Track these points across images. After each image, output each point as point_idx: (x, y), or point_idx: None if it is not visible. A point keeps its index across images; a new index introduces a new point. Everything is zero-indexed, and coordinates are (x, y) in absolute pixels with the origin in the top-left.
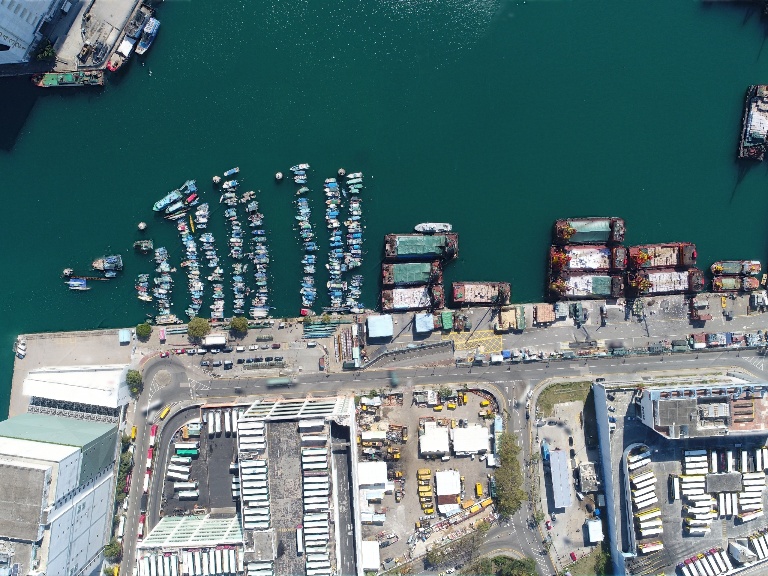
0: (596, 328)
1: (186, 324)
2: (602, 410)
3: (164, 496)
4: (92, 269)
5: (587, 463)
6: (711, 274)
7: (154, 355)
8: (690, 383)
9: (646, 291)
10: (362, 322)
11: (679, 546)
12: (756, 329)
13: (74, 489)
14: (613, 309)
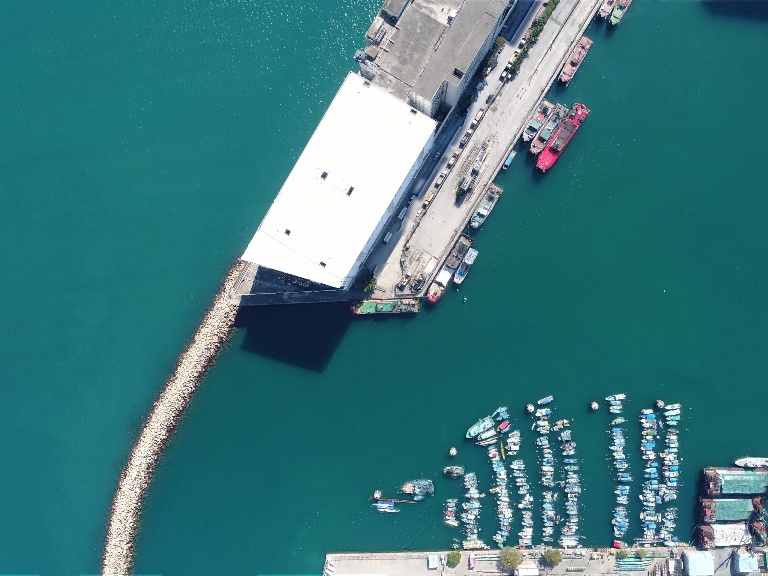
0: None
1: (494, 551)
2: None
3: None
4: (400, 492)
5: None
6: None
7: None
8: None
9: None
10: (679, 558)
11: None
12: None
13: None
14: None
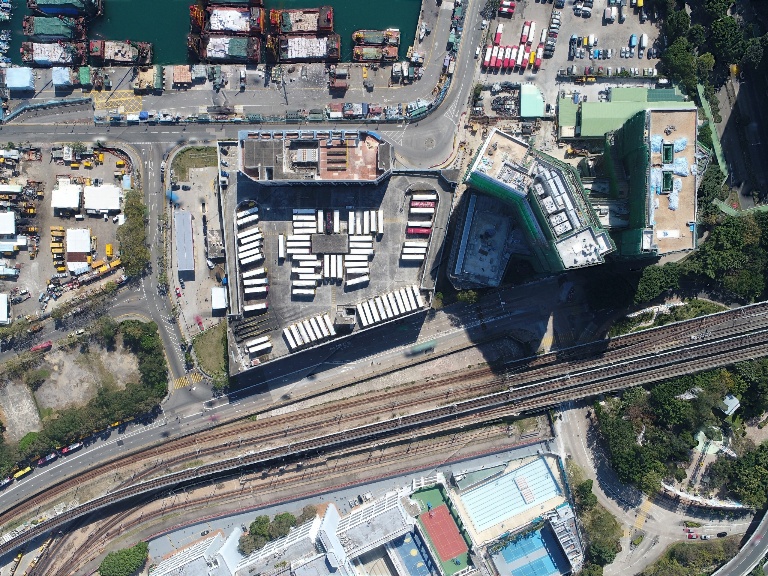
0: (235, 93)
1: None
2: None
3: None
4: None
5: (216, 229)
6: (354, 43)
7: None
8: None
9: (285, 57)
10: (5, 74)
11: (287, 310)
12: (397, 102)
13: None
14: (253, 75)
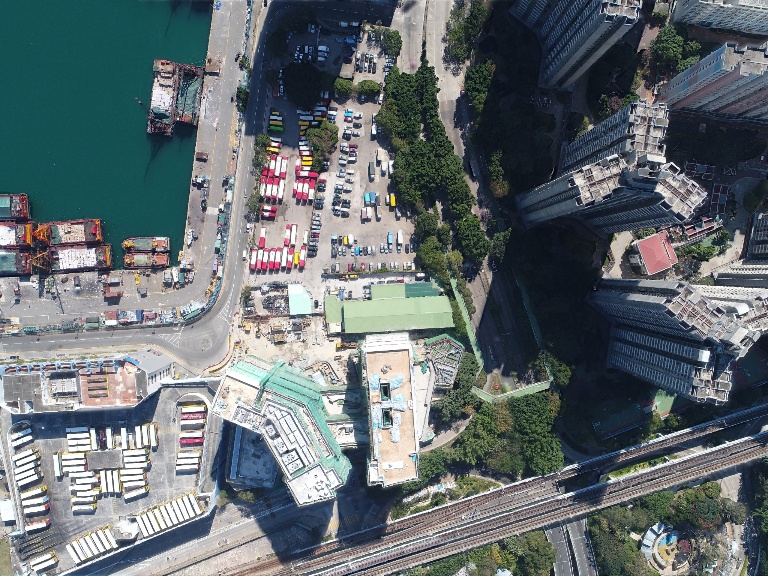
0: (10, 305)
1: None
2: None
3: None
4: None
5: None
6: None
7: None
8: (69, 359)
9: (57, 268)
10: None
11: (70, 524)
12: (171, 306)
13: None
14: (27, 286)
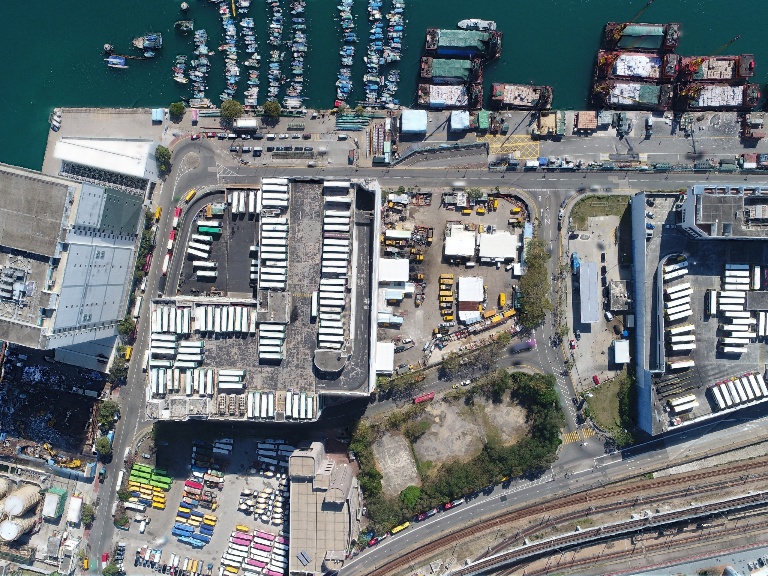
0: (639, 141)
1: (219, 108)
2: (639, 219)
3: (182, 276)
4: (132, 47)
5: (619, 280)
6: (767, 92)
7: (185, 137)
8: None
9: (696, 105)
10: (396, 116)
11: (711, 368)
12: None
13: (95, 230)
14: (659, 122)
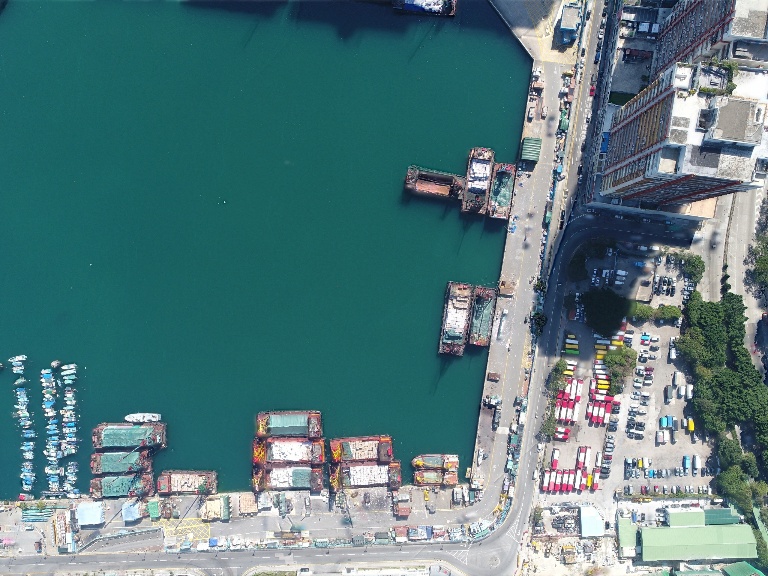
0: (301, 518)
1: None
2: None
3: None
4: None
5: None
6: (413, 467)
7: None
8: None
9: (348, 484)
10: (75, 508)
11: None
12: (459, 523)
13: None
14: (317, 500)
